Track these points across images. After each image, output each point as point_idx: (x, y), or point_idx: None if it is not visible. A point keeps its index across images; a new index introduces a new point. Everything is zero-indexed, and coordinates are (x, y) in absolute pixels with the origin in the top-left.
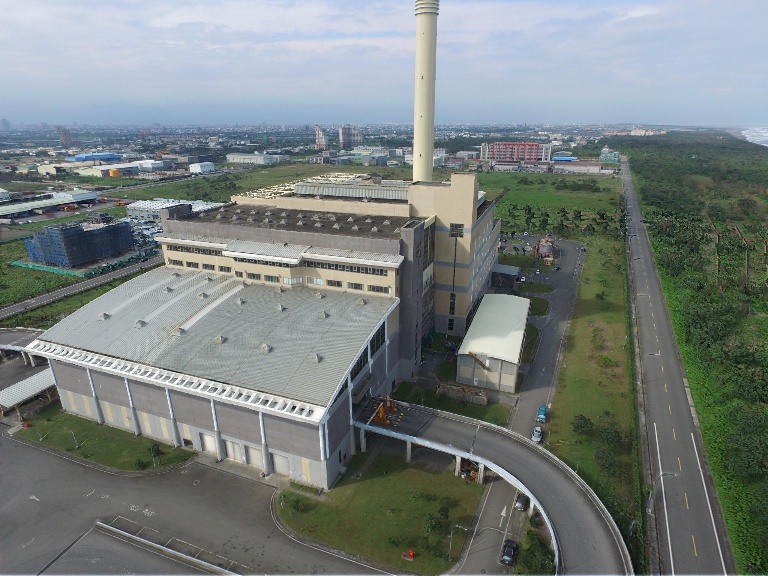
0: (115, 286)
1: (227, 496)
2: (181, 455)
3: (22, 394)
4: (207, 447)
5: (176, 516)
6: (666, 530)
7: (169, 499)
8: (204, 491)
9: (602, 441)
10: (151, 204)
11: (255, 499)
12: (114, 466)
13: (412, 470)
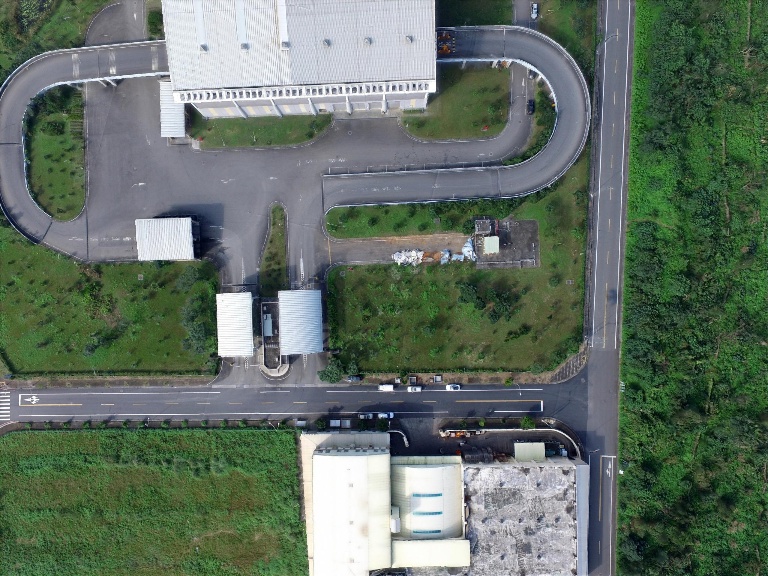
0: None
1: (374, 134)
2: (324, 119)
3: (178, 123)
4: (337, 108)
5: (358, 156)
6: (604, 61)
7: (345, 149)
8: (359, 136)
9: None
10: None
11: (391, 129)
12: (293, 143)
13: (467, 74)
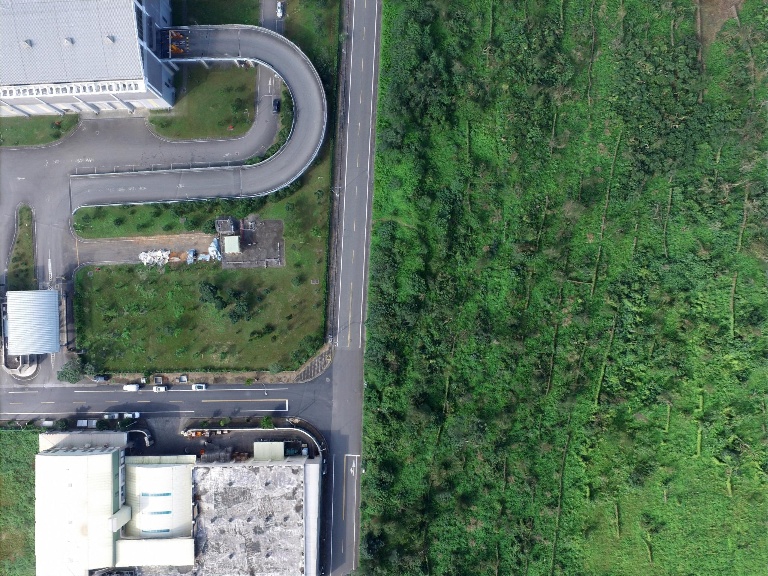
0: None
1: (121, 134)
2: (71, 119)
3: None
4: (82, 108)
5: (105, 156)
6: (350, 60)
7: (92, 149)
8: (106, 136)
9: (316, 8)
10: None
11: (138, 129)
12: (40, 143)
13: (212, 73)
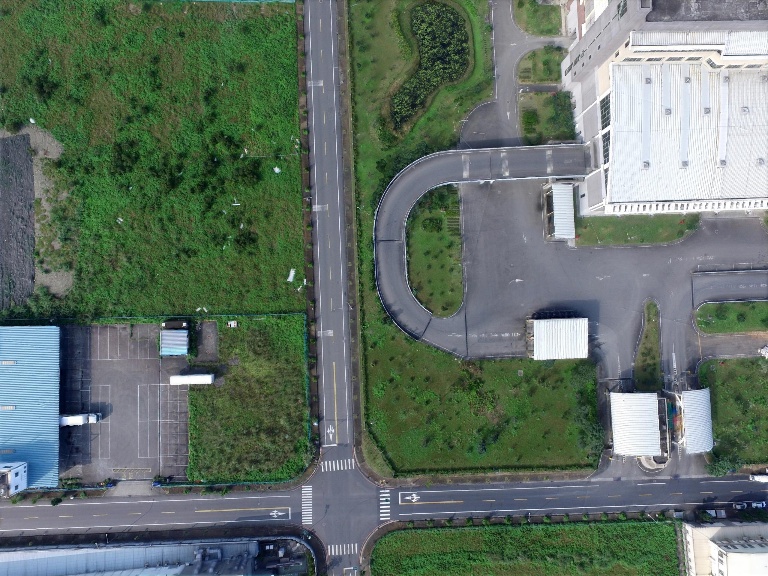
0: (373, 14)
1: (739, 233)
2: (692, 218)
3: (570, 225)
4: None
5: (725, 254)
6: None
7: (713, 247)
8: (726, 235)
9: None
10: None
11: (754, 229)
12: (664, 241)
13: None
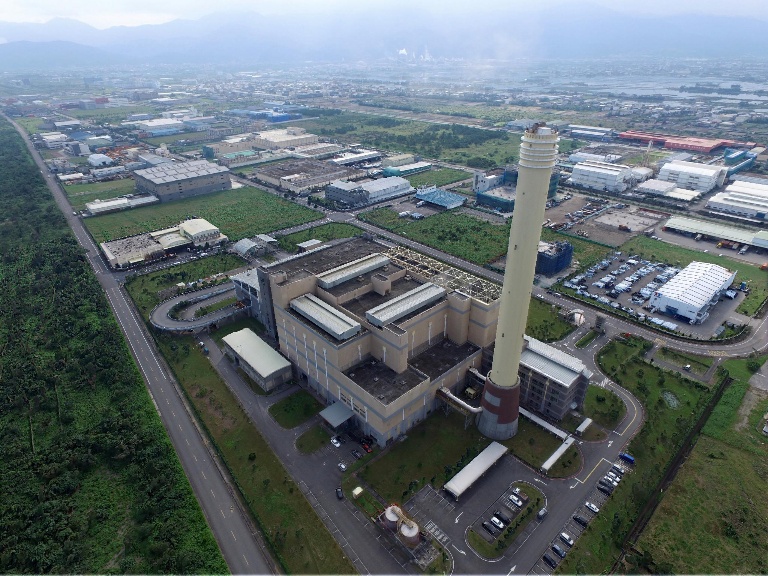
0: None
1: None
2: None
3: None
4: None
5: None
6: None
7: None
8: None
9: None
10: (697, 270)
11: None
12: None
13: None
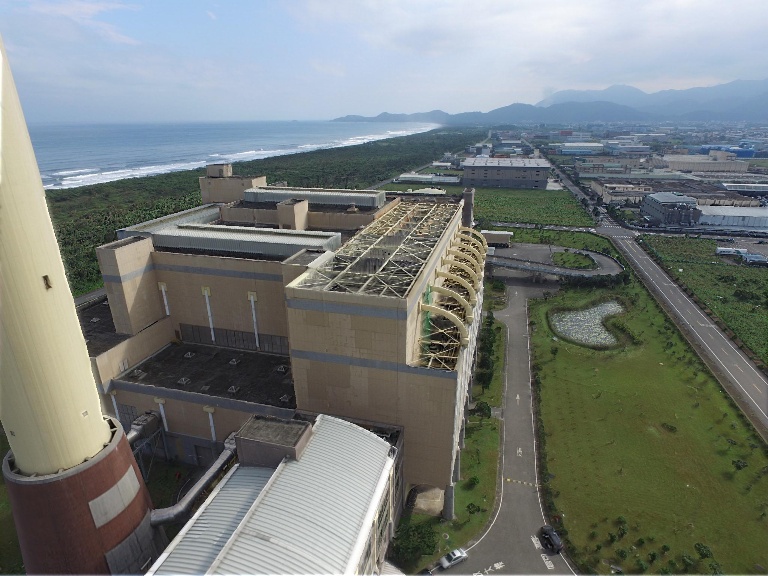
0: None
1: None
2: None
3: None
4: None
5: None
6: None
7: None
8: None
9: None
10: None
11: None
12: None
13: None
